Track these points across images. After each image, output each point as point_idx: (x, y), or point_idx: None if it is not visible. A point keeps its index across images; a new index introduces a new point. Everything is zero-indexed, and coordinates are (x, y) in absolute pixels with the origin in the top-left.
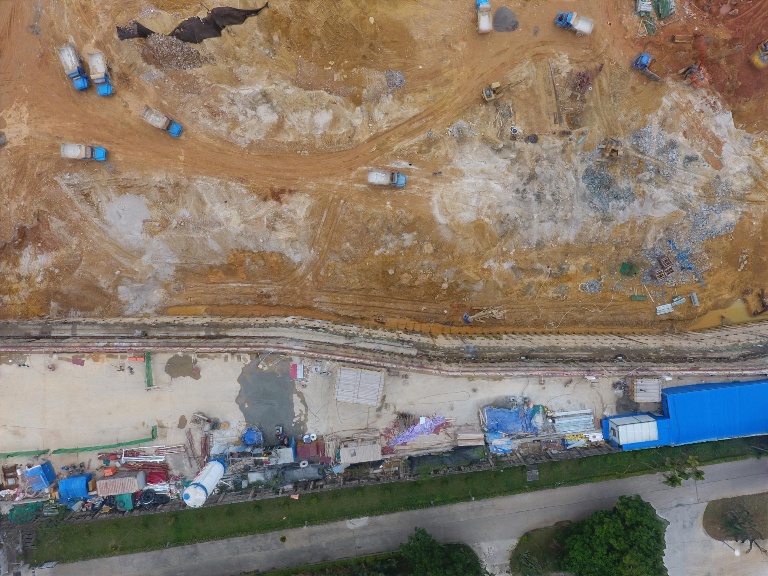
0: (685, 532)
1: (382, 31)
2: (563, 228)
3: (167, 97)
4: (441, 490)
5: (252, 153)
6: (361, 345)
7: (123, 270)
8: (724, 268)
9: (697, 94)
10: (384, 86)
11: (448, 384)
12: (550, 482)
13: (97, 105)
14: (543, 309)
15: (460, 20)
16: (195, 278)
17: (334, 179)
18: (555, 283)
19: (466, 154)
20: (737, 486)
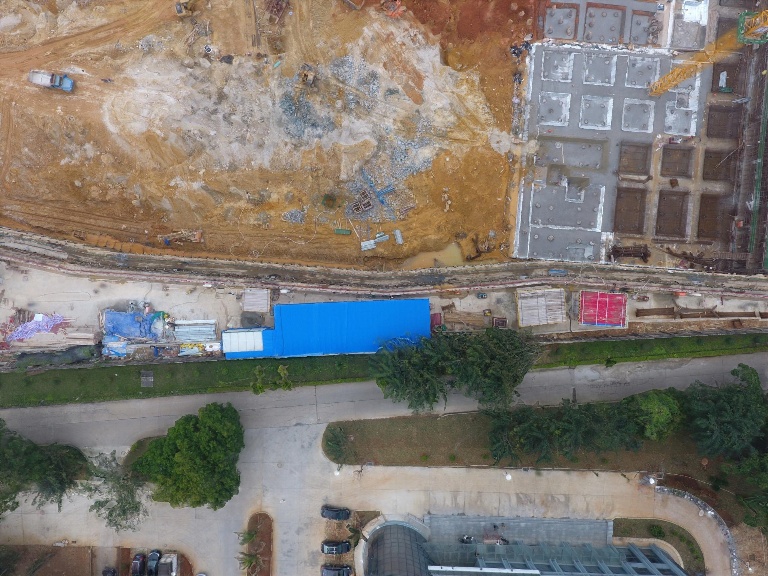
0: (303, 452)
1: None
2: (255, 151)
3: None
4: (53, 390)
5: None
6: (10, 245)
7: None
8: (430, 207)
9: (399, 26)
10: None
11: (69, 283)
12: (164, 390)
13: None
14: (247, 237)
15: None
16: None
17: (5, 80)
18: (256, 210)
19: (144, 65)
20: (359, 409)
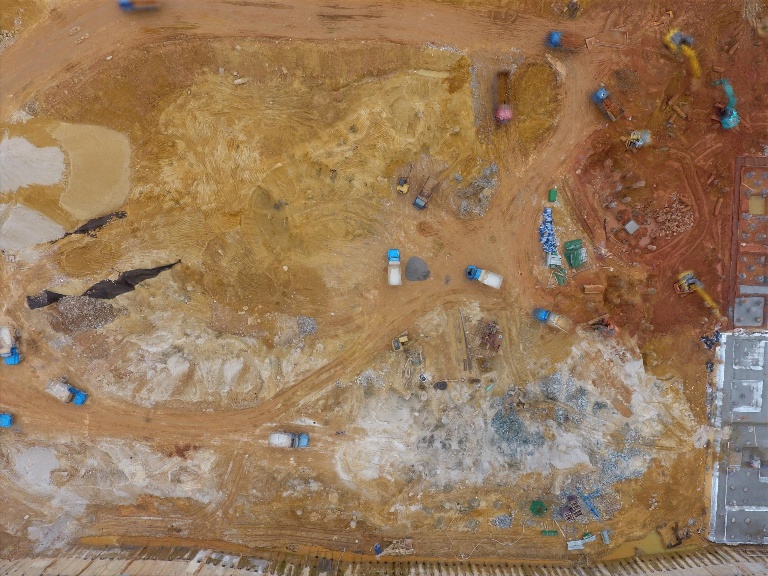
0: None
1: (296, 278)
2: (470, 473)
3: (74, 364)
4: None
5: (158, 412)
6: None
7: (32, 514)
8: (635, 507)
9: (606, 344)
10: (296, 333)
11: None
12: None
13: (6, 370)
14: (454, 540)
15: (373, 268)
16: (107, 511)
17: (239, 435)
18: (465, 518)
19: (371, 411)
20: None
